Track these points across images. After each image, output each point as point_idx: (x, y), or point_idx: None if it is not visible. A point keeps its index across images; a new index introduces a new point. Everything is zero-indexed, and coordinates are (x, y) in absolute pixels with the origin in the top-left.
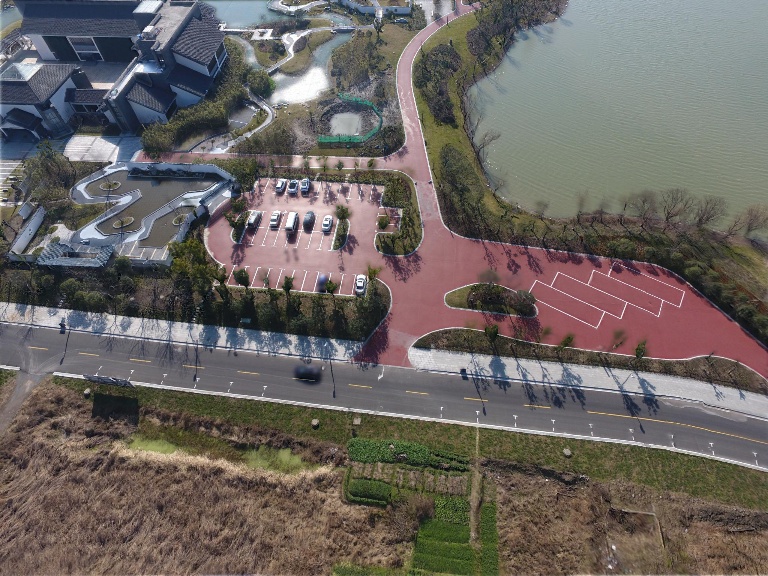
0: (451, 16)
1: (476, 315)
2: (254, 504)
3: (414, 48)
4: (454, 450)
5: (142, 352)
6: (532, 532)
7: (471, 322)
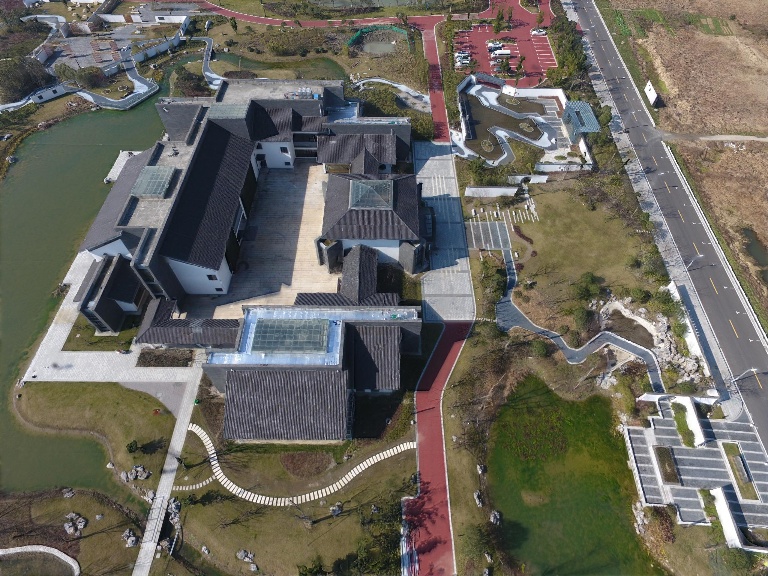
0: (204, 4)
1: (541, 6)
2: (666, 56)
3: (263, 20)
4: (613, 12)
5: (621, 98)
6: (631, 2)
7: (546, 8)
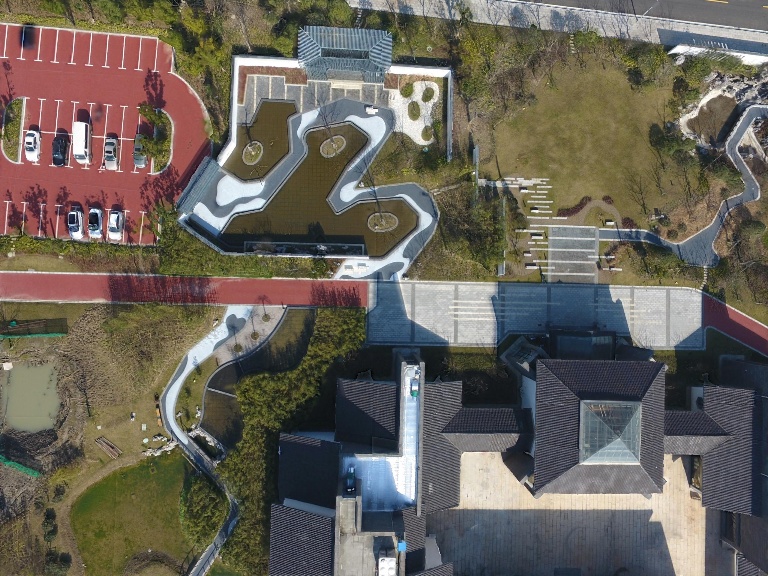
0: None
1: None
2: None
3: None
4: None
5: None
6: None
7: None
